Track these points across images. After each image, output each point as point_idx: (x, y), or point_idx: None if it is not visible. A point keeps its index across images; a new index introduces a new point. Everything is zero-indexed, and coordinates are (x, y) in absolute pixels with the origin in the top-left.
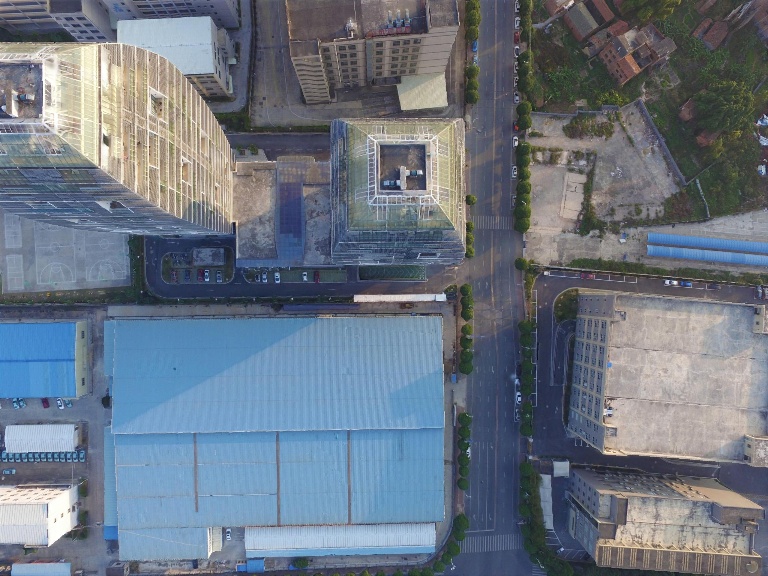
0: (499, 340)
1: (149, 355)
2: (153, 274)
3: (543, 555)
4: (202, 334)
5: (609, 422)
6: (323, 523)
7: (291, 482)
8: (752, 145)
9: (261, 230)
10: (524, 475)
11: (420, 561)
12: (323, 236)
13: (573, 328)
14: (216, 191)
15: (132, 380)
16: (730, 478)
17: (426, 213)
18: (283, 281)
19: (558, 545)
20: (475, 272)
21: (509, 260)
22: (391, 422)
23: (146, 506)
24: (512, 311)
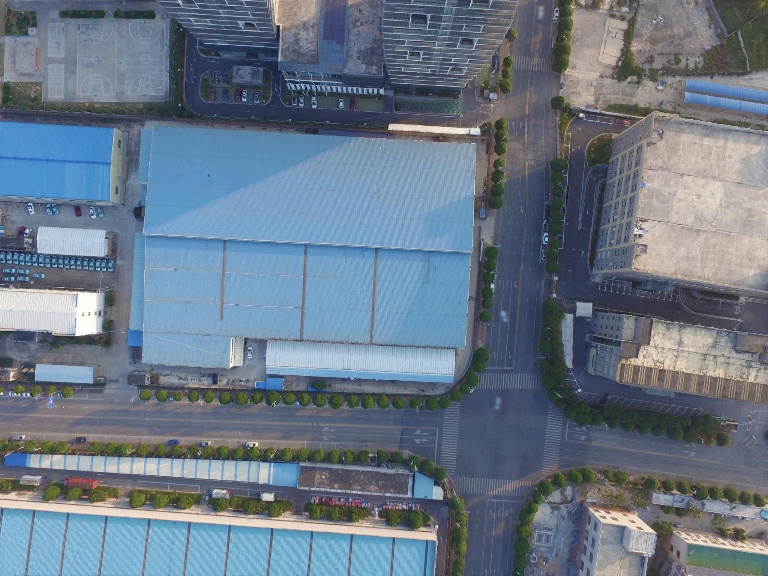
0: (530, 180)
1: (184, 161)
2: (191, 91)
3: (561, 388)
4: (238, 144)
5: None
6: (345, 341)
7: (316, 297)
8: None
9: (304, 35)
10: (547, 310)
11: (437, 393)
12: (365, 45)
13: (604, 175)
14: None
15: (166, 183)
16: None
17: None
18: (319, 107)
19: (576, 387)
20: (510, 111)
21: (545, 102)
22: (419, 242)
23: (172, 311)
24: (545, 153)
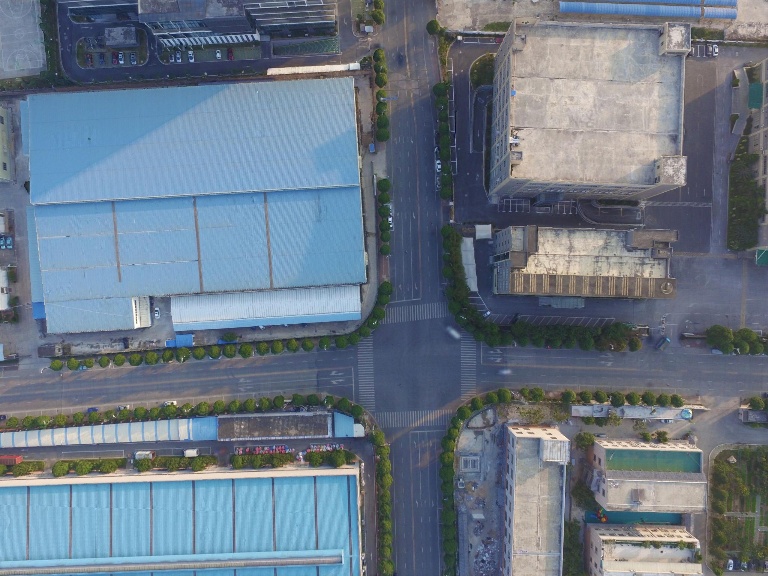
0: (416, 110)
1: (64, 127)
2: (68, 60)
3: (466, 311)
4: (115, 105)
5: None
6: (246, 288)
7: (211, 248)
8: None
9: None
10: (445, 235)
11: (348, 332)
12: None
13: (491, 97)
14: None
15: (48, 152)
16: None
17: None
18: (197, 60)
19: (485, 310)
20: (389, 43)
21: (423, 29)
22: (306, 181)
23: (70, 278)
24: (428, 80)
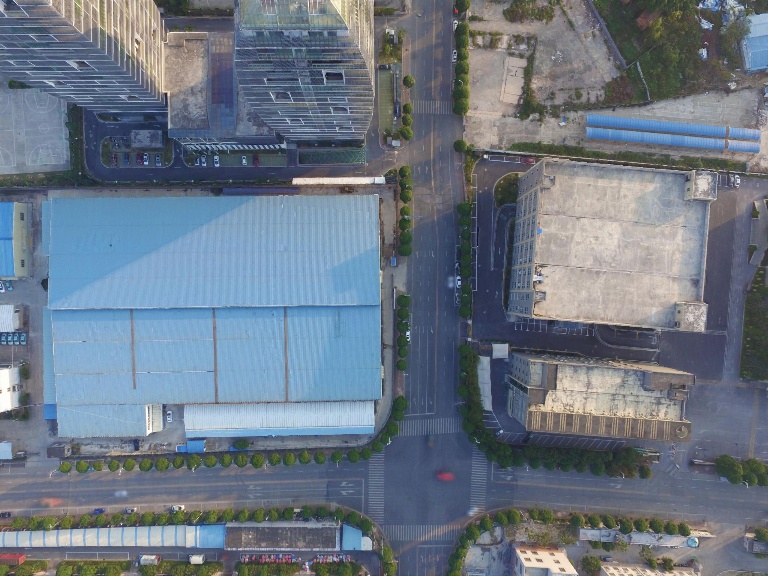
0: (439, 225)
1: (85, 232)
2: (92, 158)
3: (480, 433)
4: (138, 211)
5: (540, 289)
6: (261, 401)
7: (228, 359)
8: (693, 28)
9: (193, 101)
10: (462, 355)
11: (360, 444)
12: None
13: (514, 214)
14: (139, 46)
15: (68, 256)
16: (670, 362)
17: (315, 5)
18: (222, 165)
19: (498, 428)
20: (415, 157)
21: (449, 145)
22: (327, 298)
23: (84, 383)
24: (452, 196)
